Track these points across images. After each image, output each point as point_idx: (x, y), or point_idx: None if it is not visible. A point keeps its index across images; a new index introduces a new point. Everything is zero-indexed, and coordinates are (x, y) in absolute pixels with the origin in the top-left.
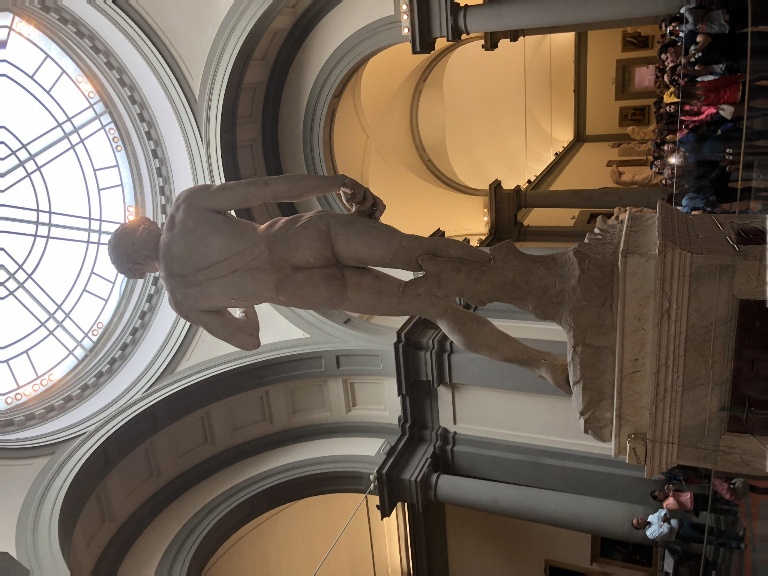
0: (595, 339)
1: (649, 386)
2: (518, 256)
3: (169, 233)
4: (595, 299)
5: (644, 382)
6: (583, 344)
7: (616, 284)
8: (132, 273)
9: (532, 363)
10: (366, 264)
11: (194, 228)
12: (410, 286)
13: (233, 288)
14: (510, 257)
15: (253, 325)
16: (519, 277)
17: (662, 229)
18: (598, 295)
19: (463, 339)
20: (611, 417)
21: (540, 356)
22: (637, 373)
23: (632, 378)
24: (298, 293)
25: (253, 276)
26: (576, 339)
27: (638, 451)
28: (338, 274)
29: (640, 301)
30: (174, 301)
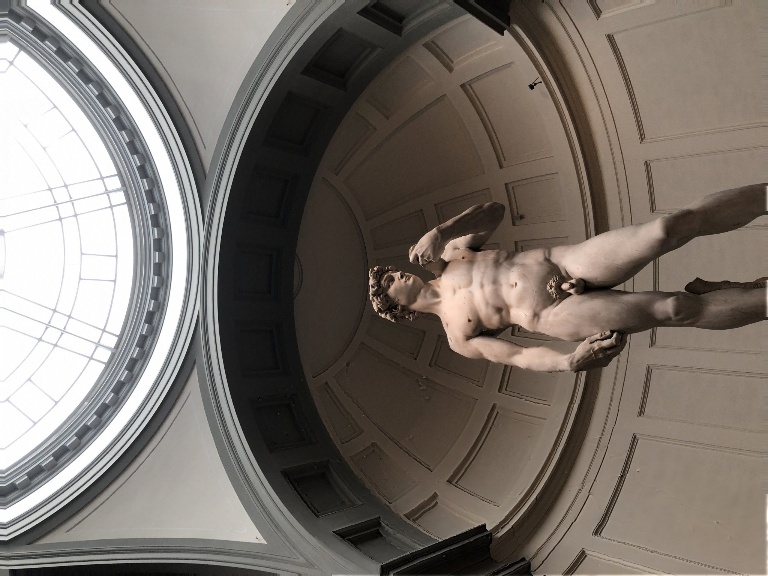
0: None
1: None
2: None
3: None
4: None
5: None
6: None
7: None
8: None
9: None
10: None
11: None
12: None
13: None
14: None
15: (493, 225)
16: None
17: None
18: None
19: None
20: None
21: None
22: None
23: None
24: None
25: None
26: None
27: None
28: None
29: None
30: None
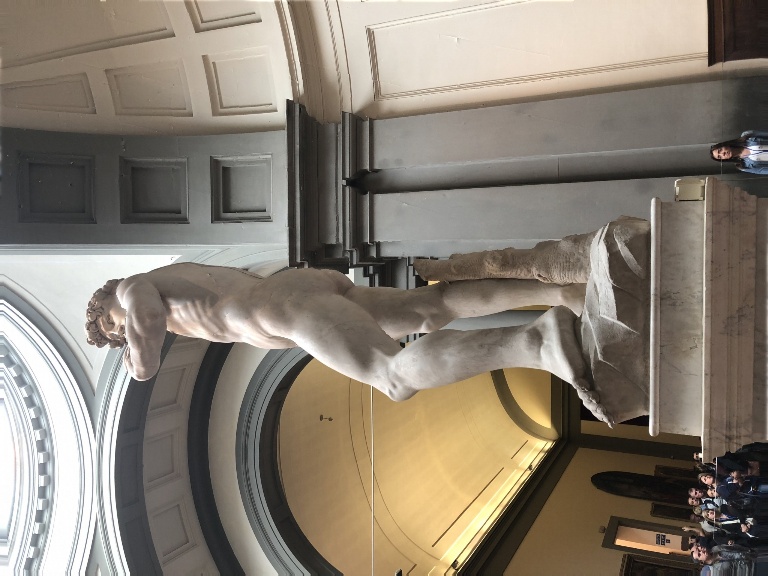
0: None
1: None
2: None
3: None
4: None
5: None
6: None
7: None
8: (104, 297)
9: None
10: (373, 295)
11: None
12: None
13: None
14: None
15: None
16: None
17: None
18: None
19: None
20: None
21: None
22: None
23: None
24: None
25: None
26: None
27: None
28: None
29: None
30: None
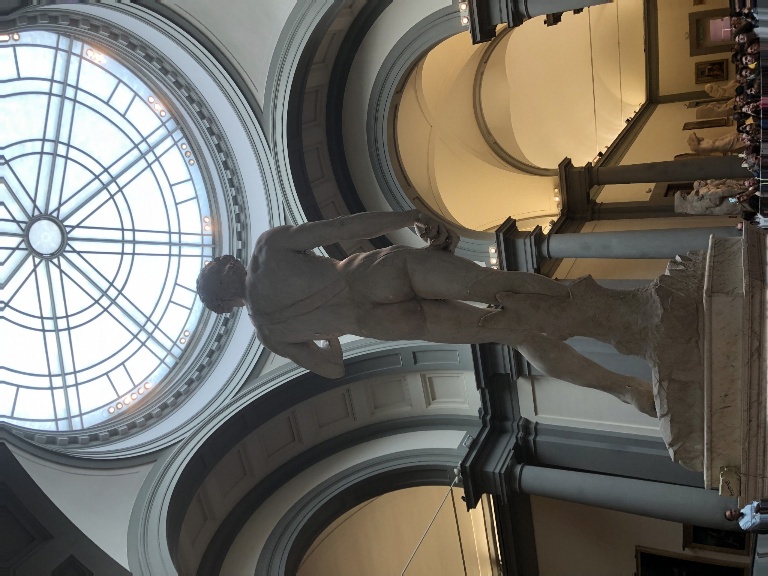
0: (681, 374)
1: (741, 421)
2: (597, 292)
3: (254, 274)
4: (680, 337)
5: (735, 417)
6: (669, 379)
7: (701, 321)
8: (221, 308)
9: (616, 389)
10: (444, 298)
11: (277, 269)
12: (489, 321)
13: (317, 323)
14: (589, 293)
15: (337, 353)
16: (600, 313)
17: (748, 264)
18: (683, 333)
19: (544, 365)
20: (702, 449)
21: (624, 382)
22: (727, 408)
23: (722, 413)
24: (380, 328)
25: (335, 311)
26: (662, 374)
27: (732, 485)
28: (417, 308)
29: (728, 339)
30: (262, 335)
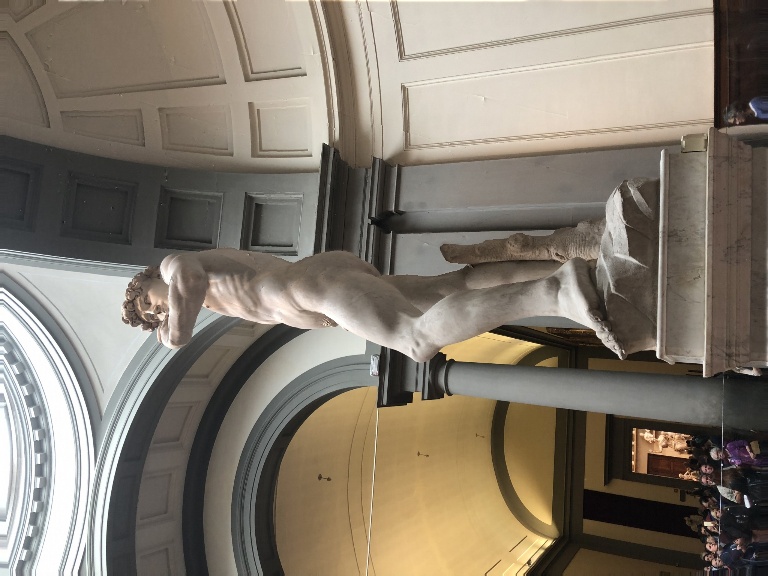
0: None
1: None
2: None
3: None
4: None
5: None
6: None
7: None
8: (144, 280)
9: None
10: (400, 279)
11: None
12: None
13: None
14: None
15: None
16: None
17: None
18: None
19: None
20: None
21: None
22: None
23: None
24: None
25: None
26: None
27: None
28: None
29: None
30: None
